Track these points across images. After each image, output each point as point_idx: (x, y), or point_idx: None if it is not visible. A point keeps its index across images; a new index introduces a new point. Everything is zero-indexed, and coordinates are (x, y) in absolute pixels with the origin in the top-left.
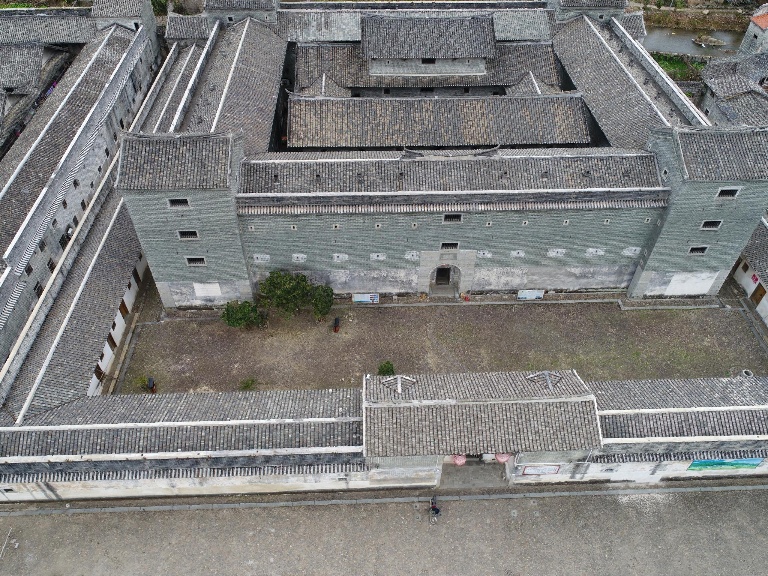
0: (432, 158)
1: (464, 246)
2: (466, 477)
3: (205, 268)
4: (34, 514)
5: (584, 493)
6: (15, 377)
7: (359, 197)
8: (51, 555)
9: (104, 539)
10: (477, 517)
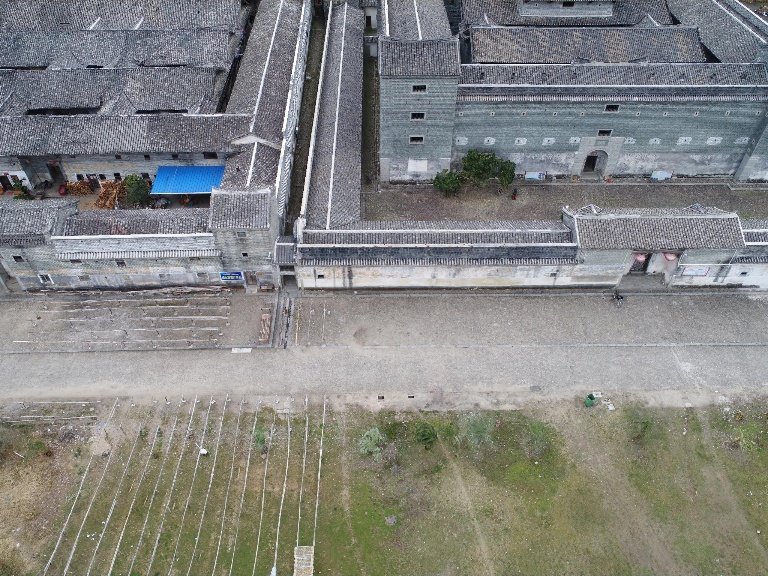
0: (596, 64)
1: (615, 133)
2: (636, 283)
3: (421, 146)
4: (333, 297)
5: (723, 293)
6: (306, 209)
7: (547, 88)
8: (355, 318)
9: (388, 311)
10: (649, 304)
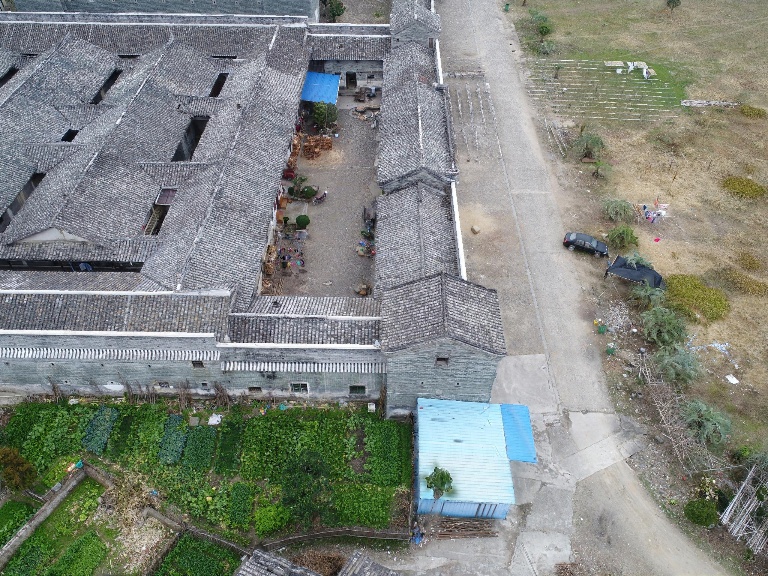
0: None
1: None
2: None
3: None
4: None
5: None
6: None
7: None
8: None
9: None
10: None
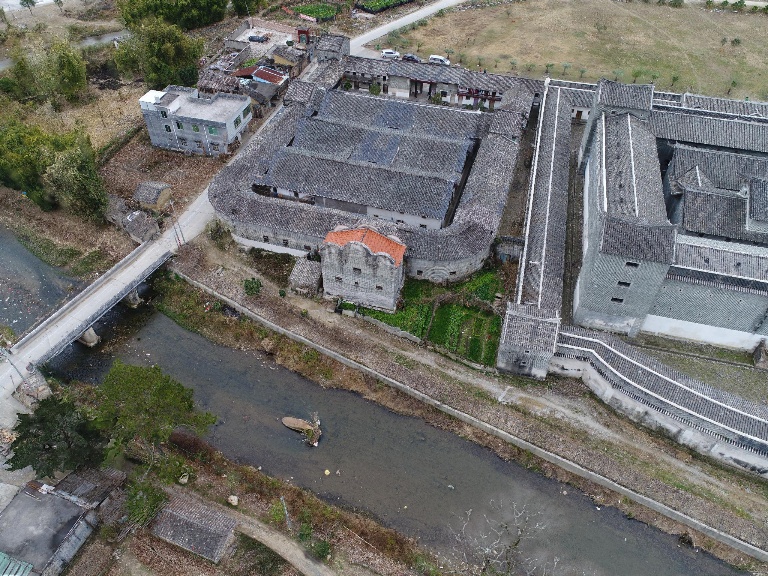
0: None
1: None
2: None
3: None
4: None
5: None
6: None
7: None
8: None
9: None
10: None
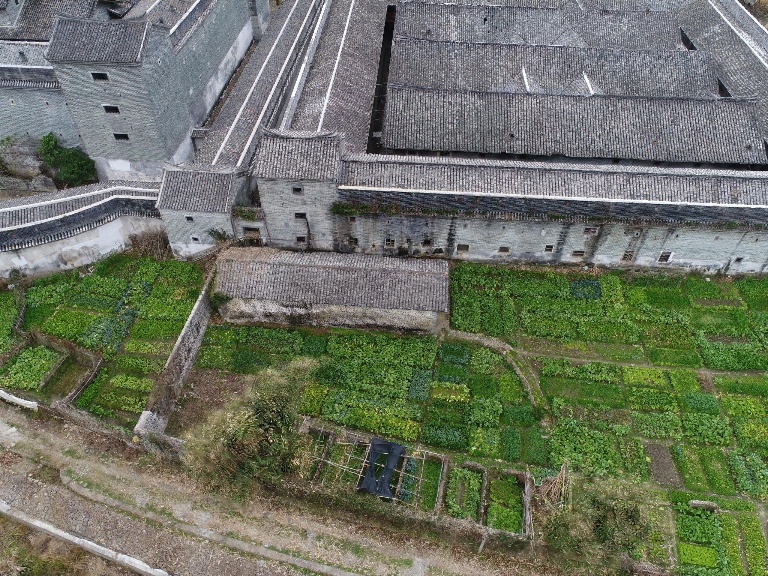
0: None
1: None
2: None
3: None
4: None
5: None
6: None
7: None
8: None
9: None
10: None
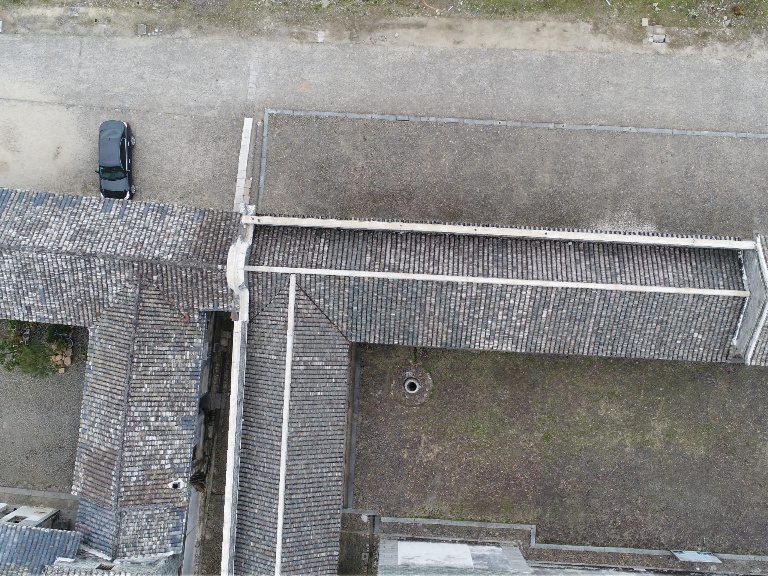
0: None
1: None
2: None
3: None
4: None
5: None
6: None
7: None
8: None
9: None
10: None
